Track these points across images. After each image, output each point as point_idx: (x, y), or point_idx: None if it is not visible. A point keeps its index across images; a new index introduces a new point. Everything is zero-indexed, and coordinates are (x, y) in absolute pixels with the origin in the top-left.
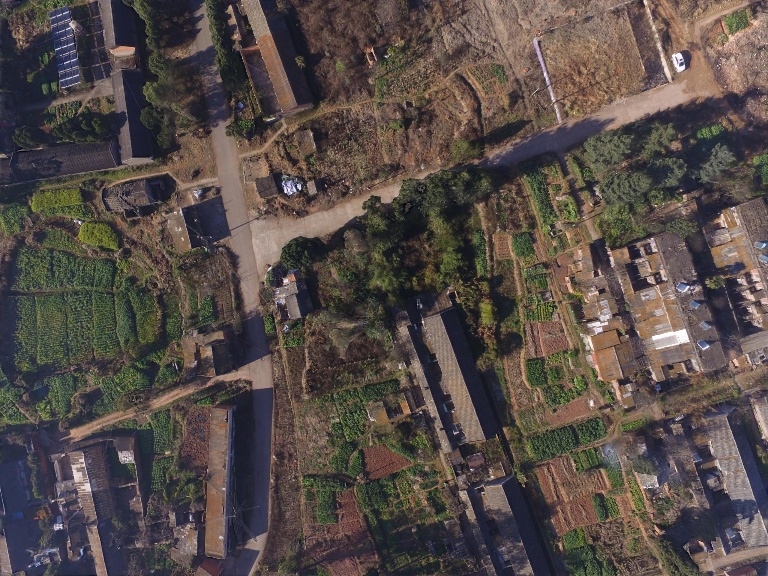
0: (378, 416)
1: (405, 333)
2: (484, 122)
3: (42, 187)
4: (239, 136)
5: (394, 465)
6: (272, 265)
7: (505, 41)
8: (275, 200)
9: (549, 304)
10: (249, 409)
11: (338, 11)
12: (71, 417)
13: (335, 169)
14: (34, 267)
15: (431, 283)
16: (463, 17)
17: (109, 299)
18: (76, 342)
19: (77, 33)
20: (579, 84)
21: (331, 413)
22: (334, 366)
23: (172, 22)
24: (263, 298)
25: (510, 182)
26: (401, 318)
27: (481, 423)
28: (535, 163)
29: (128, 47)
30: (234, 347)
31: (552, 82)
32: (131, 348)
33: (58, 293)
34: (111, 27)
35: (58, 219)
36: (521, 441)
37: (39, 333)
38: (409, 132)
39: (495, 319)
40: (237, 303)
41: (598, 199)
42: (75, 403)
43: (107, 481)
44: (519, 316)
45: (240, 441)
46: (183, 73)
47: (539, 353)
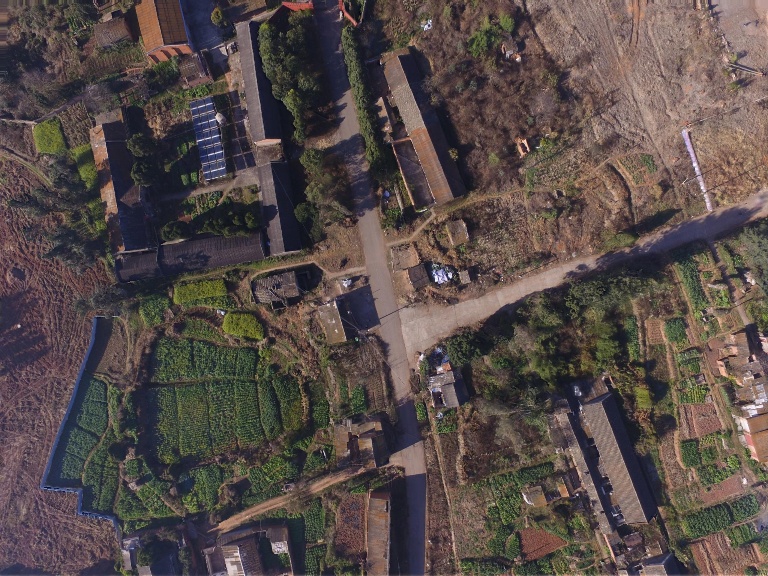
0: (536, 500)
1: (564, 420)
2: (635, 211)
3: (183, 278)
4: (393, 228)
5: (550, 546)
6: (423, 352)
7: (654, 131)
8: (425, 288)
9: (702, 387)
10: (403, 495)
11: (488, 102)
12: (219, 508)
13: (486, 257)
14: (174, 358)
15: (587, 370)
16: (612, 108)
17: (252, 388)
18: (219, 432)
19: (221, 125)
20: (729, 174)
21: (487, 497)
22: (491, 452)
23: (316, 112)
24: (414, 385)
25: (662, 269)
26: (560, 405)
27: (642, 506)
28: (686, 251)
29: (275, 139)
30: (386, 434)
31: (703, 172)
32: (283, 439)
33: (199, 383)
34: (260, 120)
35: (199, 310)
36: (676, 519)
37: (180, 424)
38: (560, 220)
39: (653, 404)
40: (389, 391)
41: (749, 286)
42: (222, 494)
43: (262, 573)
44: (672, 399)
45: (395, 528)
46: (328, 163)
47: (693, 434)
